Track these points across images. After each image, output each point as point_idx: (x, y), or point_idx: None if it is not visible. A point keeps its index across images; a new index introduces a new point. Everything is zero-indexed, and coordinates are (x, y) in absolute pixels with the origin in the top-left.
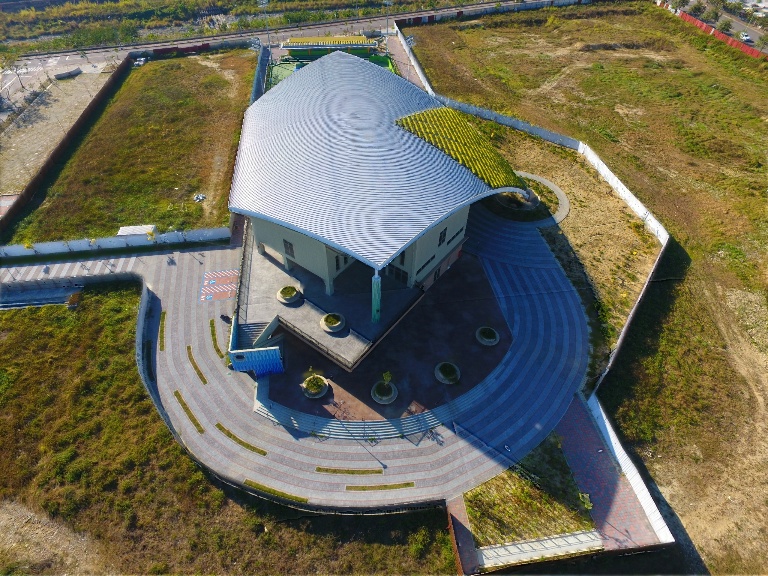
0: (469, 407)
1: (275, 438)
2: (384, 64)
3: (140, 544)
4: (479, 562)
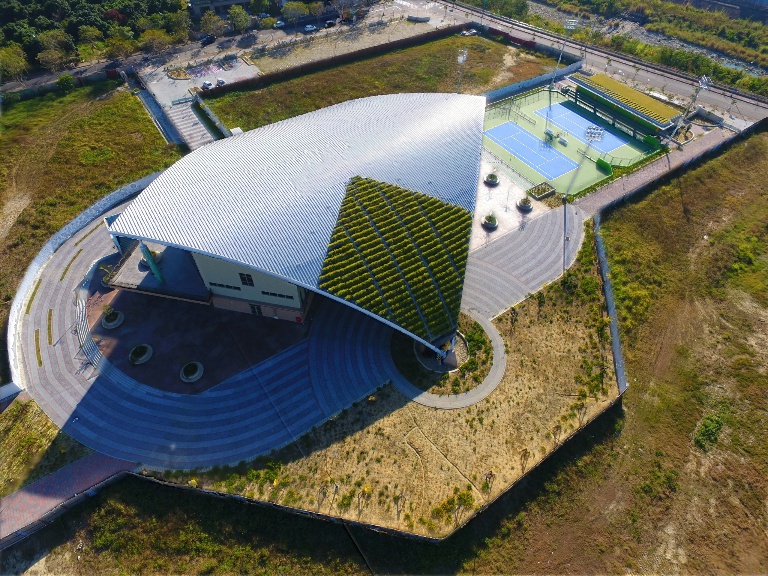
0: (114, 382)
1: (74, 279)
2: (650, 152)
3: (1, 255)
4: None
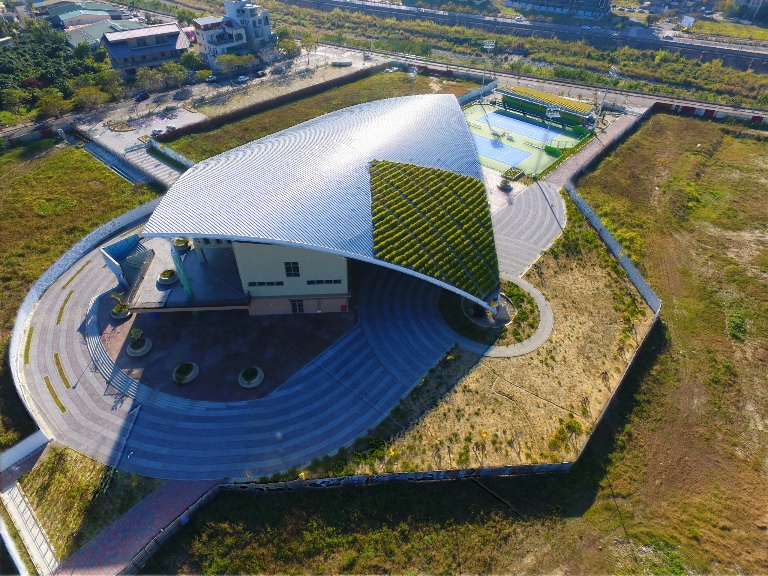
0: (162, 407)
1: (73, 320)
2: (582, 137)
3: None
4: (5, 488)
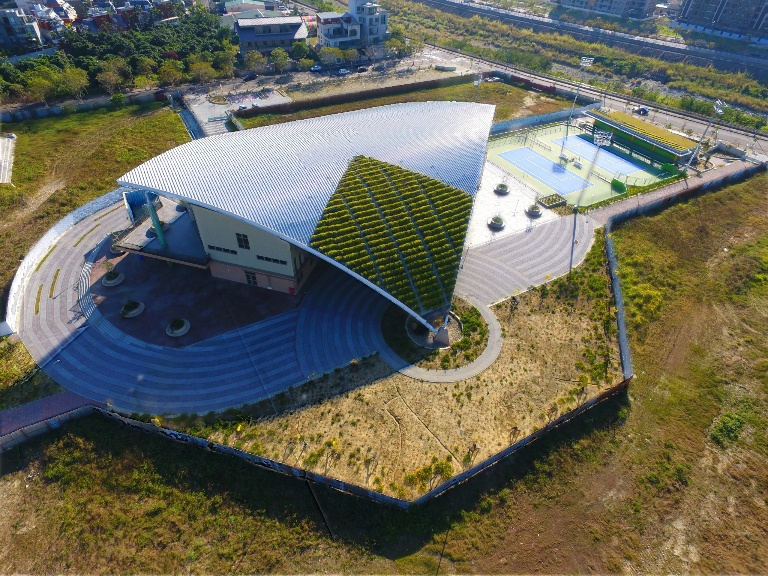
0: (102, 332)
1: (86, 247)
2: (667, 177)
3: None
4: None
